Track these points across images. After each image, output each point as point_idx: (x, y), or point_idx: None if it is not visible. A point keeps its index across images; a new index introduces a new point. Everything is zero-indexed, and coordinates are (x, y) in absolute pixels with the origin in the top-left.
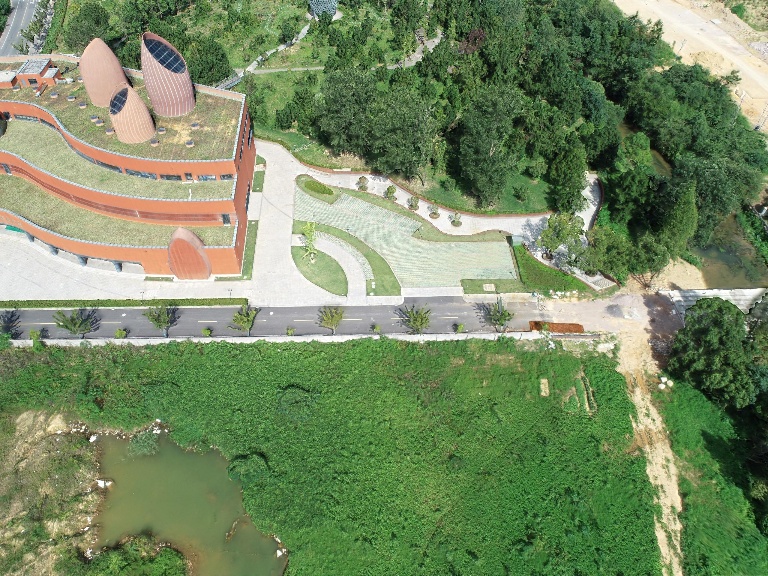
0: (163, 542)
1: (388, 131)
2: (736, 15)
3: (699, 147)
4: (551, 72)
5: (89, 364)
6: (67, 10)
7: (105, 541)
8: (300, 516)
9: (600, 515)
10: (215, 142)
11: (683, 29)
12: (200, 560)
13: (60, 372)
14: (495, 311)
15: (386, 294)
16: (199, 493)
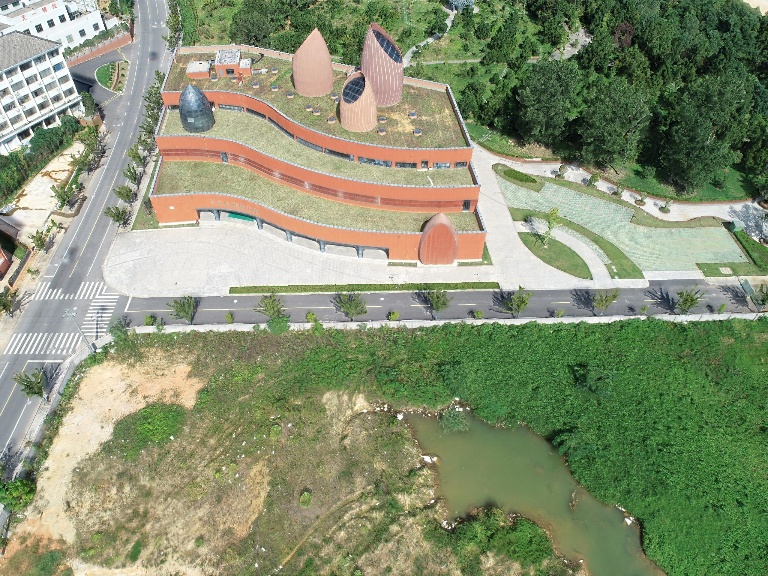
0: (512, 513)
1: (604, 120)
2: None
3: None
4: (722, 64)
5: (371, 346)
6: (195, 3)
7: (455, 513)
8: (641, 486)
9: None
10: (440, 131)
11: None
12: (555, 529)
13: (345, 354)
14: (760, 292)
15: (630, 277)
16: (524, 467)
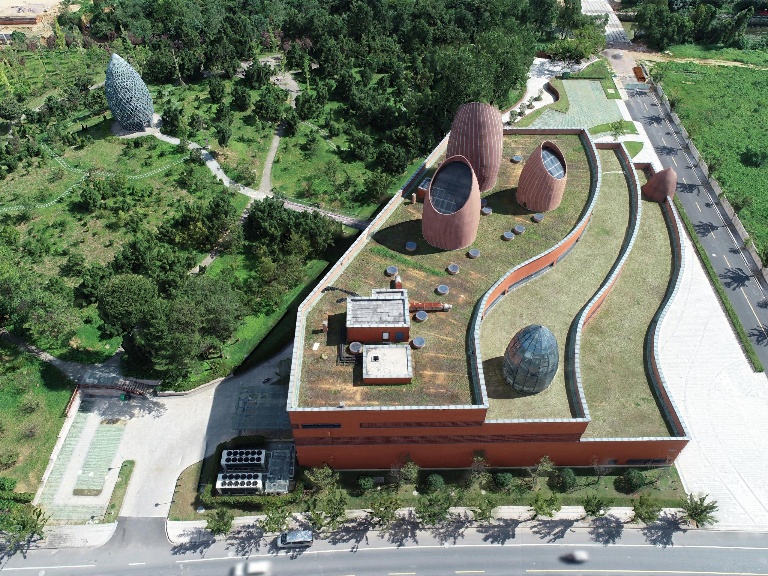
0: None
1: None
2: None
3: (455, 2)
4: (383, 10)
5: None
6: None
7: None
8: None
9: (760, 79)
10: None
11: None
12: None
13: None
14: None
15: (634, 127)
16: None
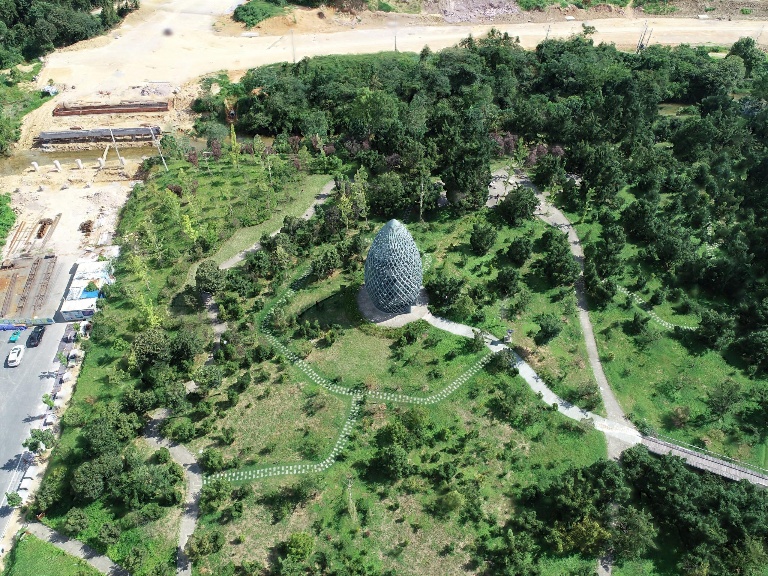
0: None
1: None
2: (393, 12)
3: None
4: None
5: None
6: None
7: None
8: None
9: None
10: None
11: (409, 42)
12: None
13: None
14: None
15: None
16: None
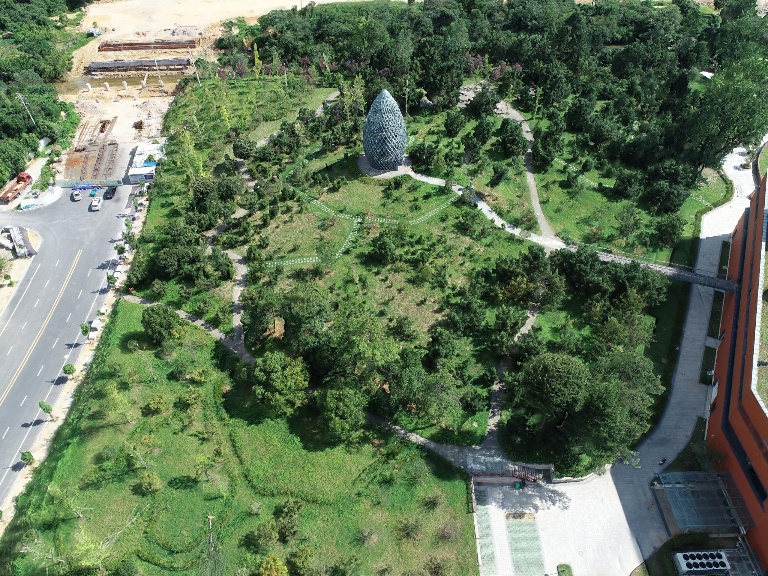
0: None
1: None
2: None
3: None
4: None
5: None
6: None
7: None
8: None
9: None
10: None
11: None
12: None
13: None
14: None
15: None
16: None
